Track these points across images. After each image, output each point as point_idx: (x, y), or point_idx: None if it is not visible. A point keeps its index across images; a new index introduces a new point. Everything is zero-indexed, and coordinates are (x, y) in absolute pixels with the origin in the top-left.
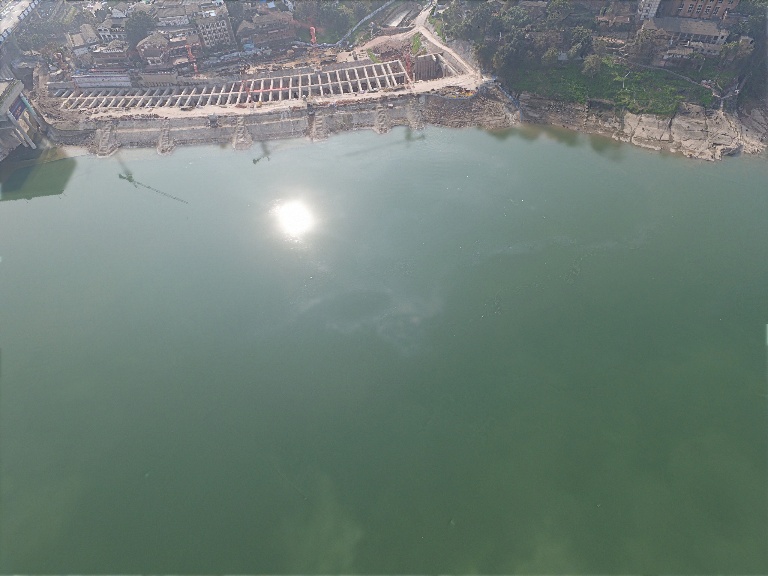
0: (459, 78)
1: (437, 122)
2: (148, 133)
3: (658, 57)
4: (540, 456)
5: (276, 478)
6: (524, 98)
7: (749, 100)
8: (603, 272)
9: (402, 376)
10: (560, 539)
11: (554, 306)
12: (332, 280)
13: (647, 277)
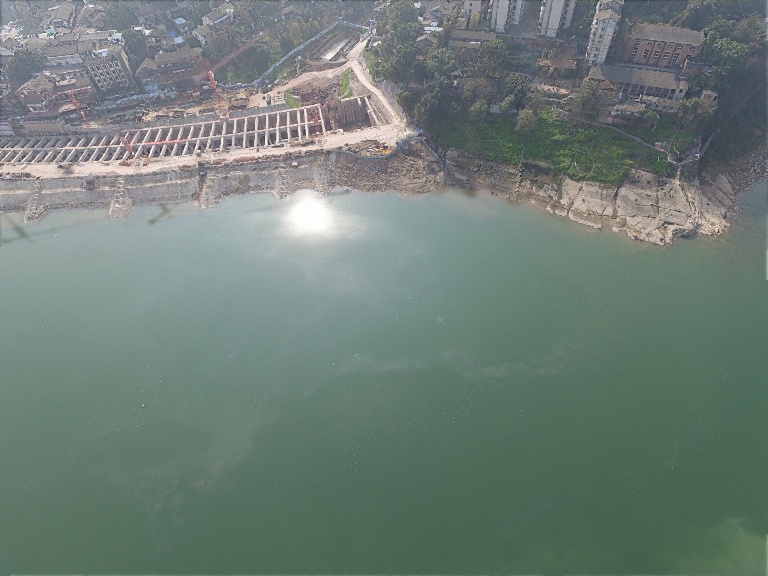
0: (380, 129)
1: (347, 185)
2: (16, 196)
3: (604, 113)
4: None
5: None
6: (451, 156)
7: (715, 163)
8: (500, 407)
9: (210, 568)
10: None
11: (431, 456)
12: (168, 409)
13: (552, 418)
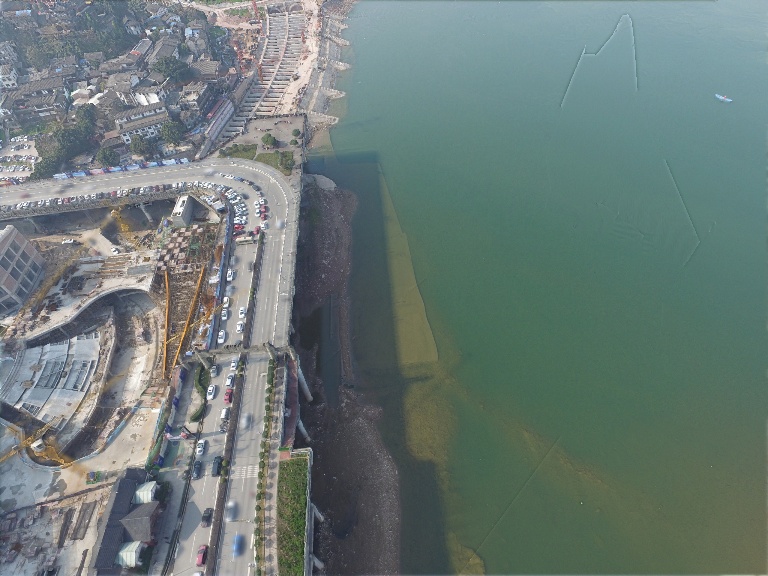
0: None
1: (343, 13)
2: (319, 96)
3: None
4: (555, 0)
5: (579, 39)
6: None
7: None
8: None
9: (532, 14)
10: (580, 2)
11: None
12: (478, 31)
13: None
